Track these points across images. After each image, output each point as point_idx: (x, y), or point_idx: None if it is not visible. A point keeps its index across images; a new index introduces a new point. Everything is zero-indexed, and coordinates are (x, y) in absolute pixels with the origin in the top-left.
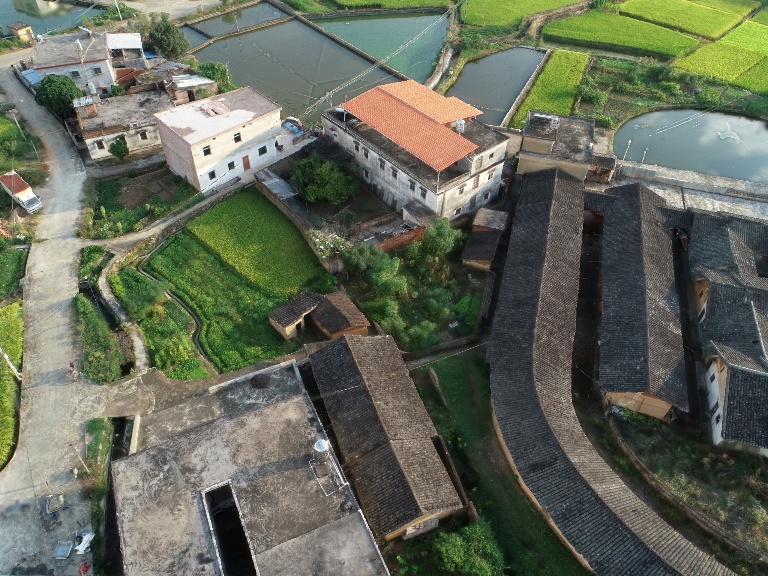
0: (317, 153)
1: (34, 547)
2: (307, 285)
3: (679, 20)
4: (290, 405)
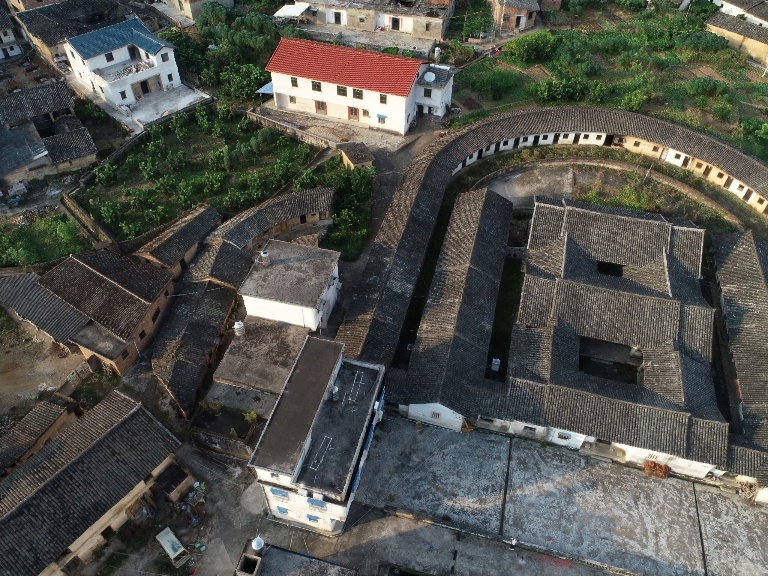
0: None
1: None
2: None
3: None
4: None
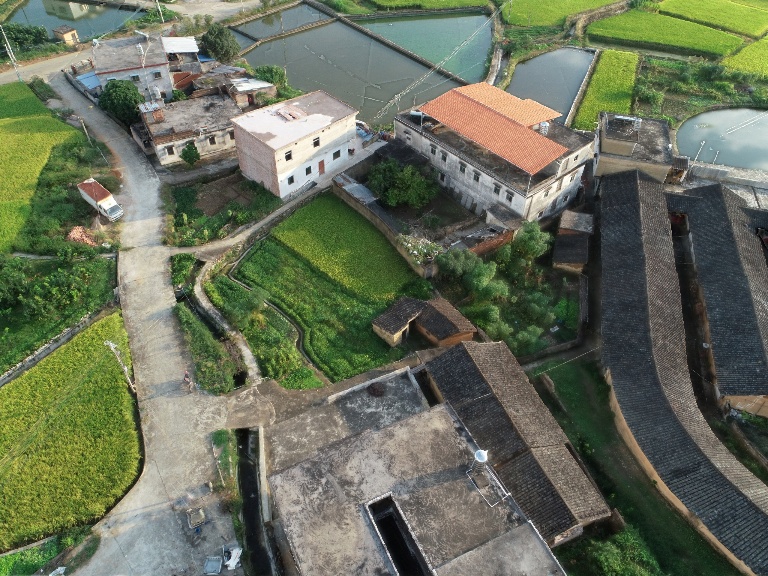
0: (391, 157)
1: (183, 563)
2: (403, 291)
3: (720, 19)
4: (434, 415)
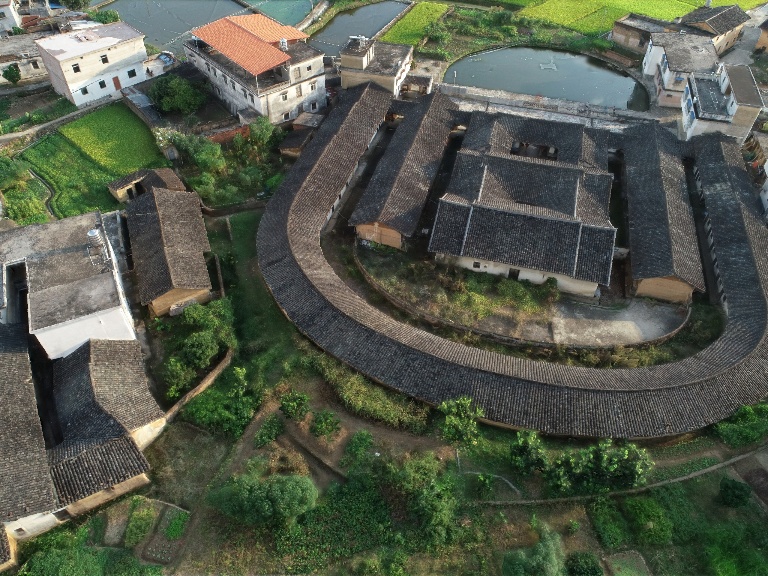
0: (178, 75)
1: None
2: (147, 167)
3: None
4: (84, 217)
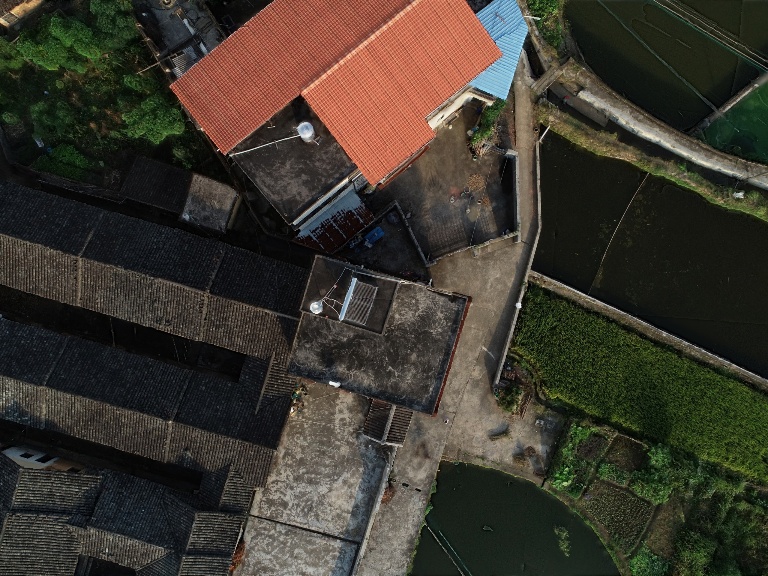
0: None
1: None
2: None
3: None
4: None
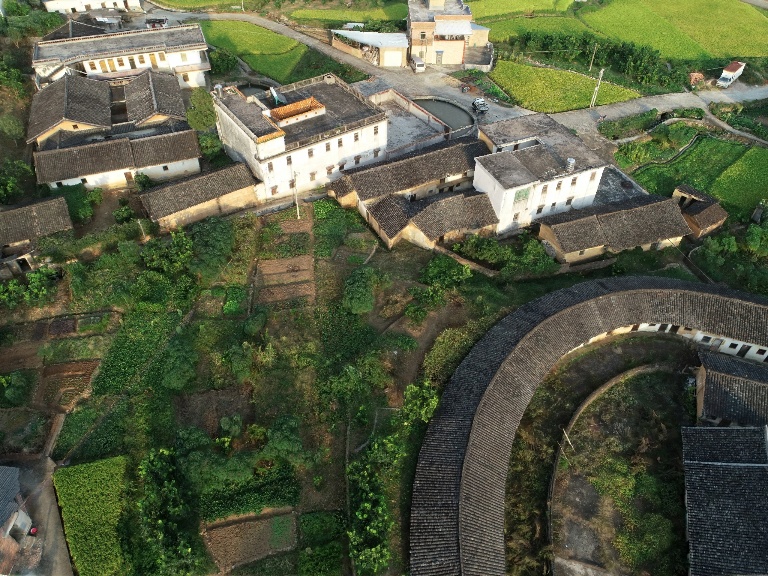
0: None
1: None
2: (730, 206)
3: None
4: (598, 159)
